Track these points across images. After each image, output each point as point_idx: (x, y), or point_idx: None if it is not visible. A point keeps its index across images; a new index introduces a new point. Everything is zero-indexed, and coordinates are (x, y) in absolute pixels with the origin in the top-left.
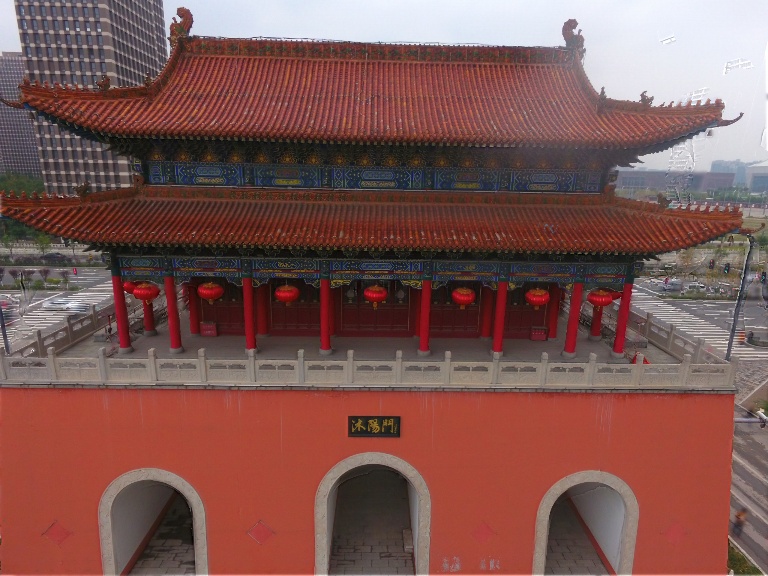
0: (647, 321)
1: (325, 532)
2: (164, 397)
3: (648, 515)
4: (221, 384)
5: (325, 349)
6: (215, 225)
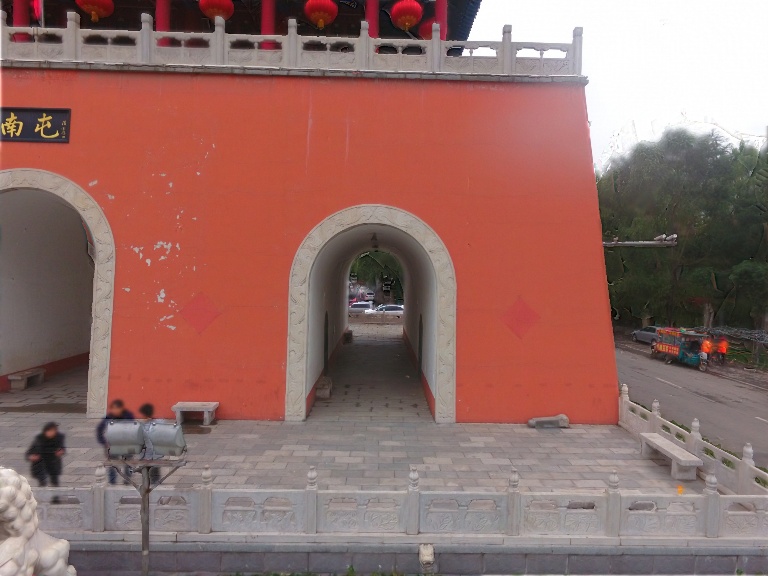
0: None
1: None
2: None
3: None
4: None
5: None
6: None
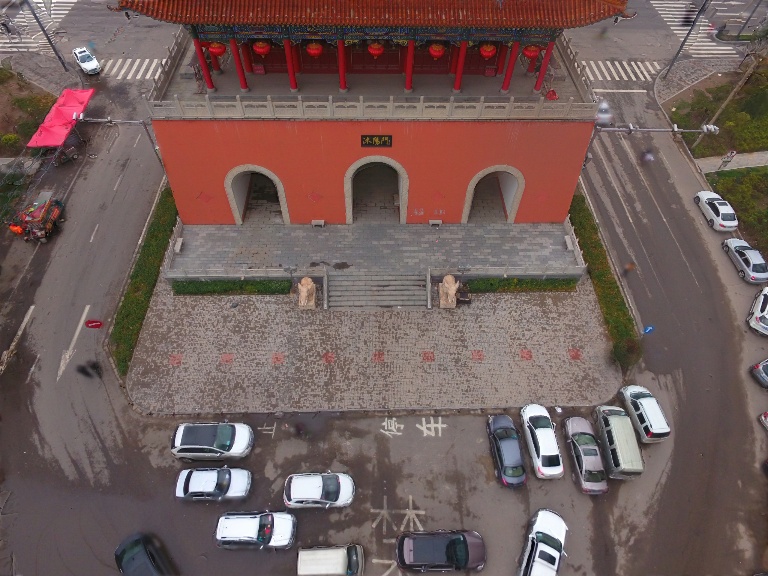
0: (574, 58)
1: (350, 197)
2: (251, 125)
3: (530, 188)
4: (284, 117)
5: (343, 89)
6: (262, 4)
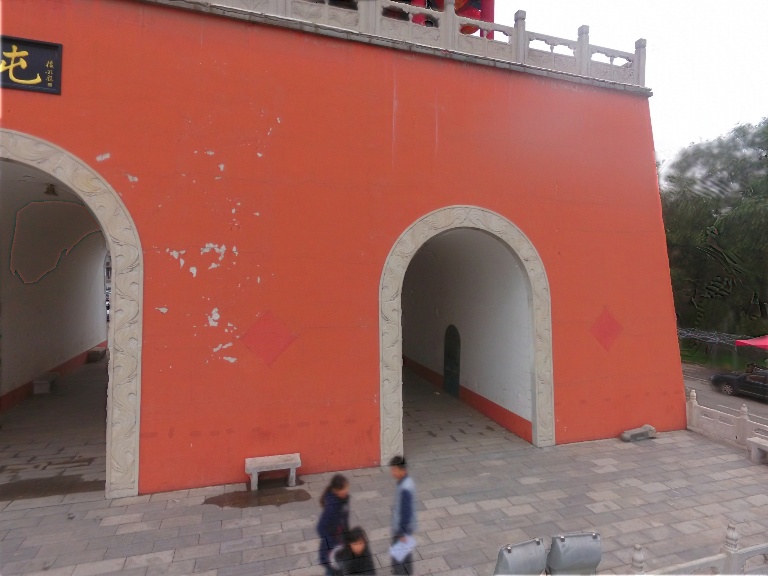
0: None
1: None
2: None
3: None
4: None
5: None
6: None
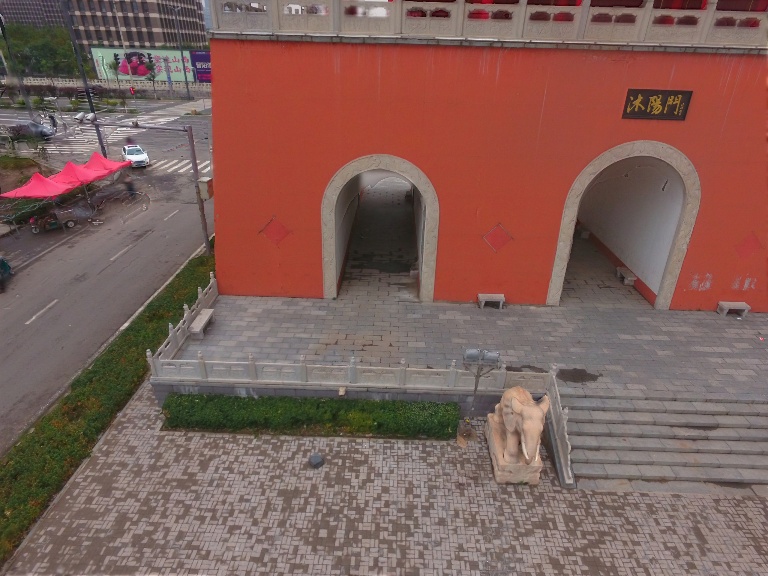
0: None
1: (570, 239)
2: (409, 56)
3: None
4: (481, 38)
5: None
6: None
